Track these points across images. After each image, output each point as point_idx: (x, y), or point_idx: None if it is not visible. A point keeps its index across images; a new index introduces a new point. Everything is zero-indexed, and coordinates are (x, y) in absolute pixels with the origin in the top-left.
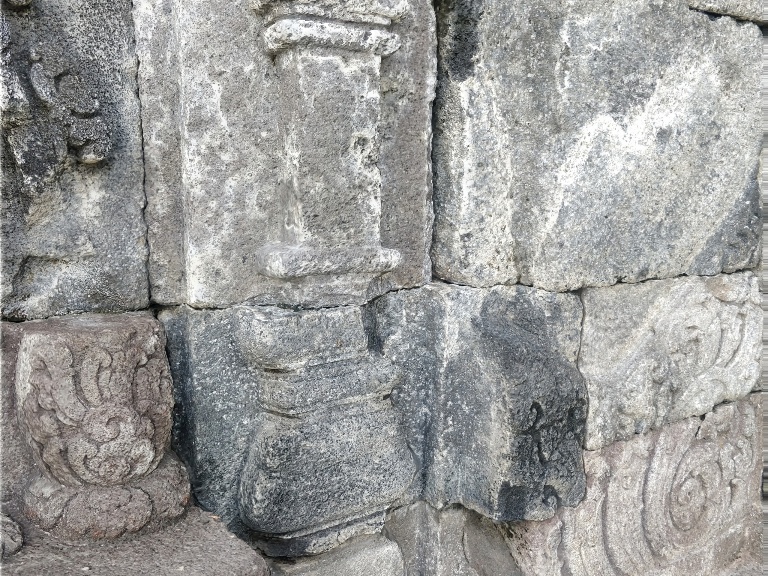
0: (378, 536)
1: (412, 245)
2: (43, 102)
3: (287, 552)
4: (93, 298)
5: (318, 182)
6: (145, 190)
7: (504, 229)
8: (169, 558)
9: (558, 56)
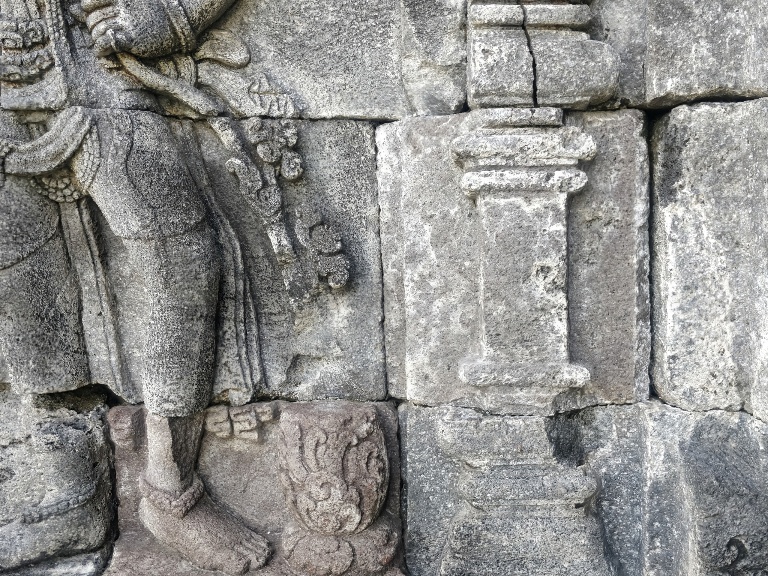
0: None
1: (621, 363)
2: None
3: None
4: (345, 389)
5: (501, 306)
6: (384, 307)
7: (723, 353)
8: None
9: (766, 177)
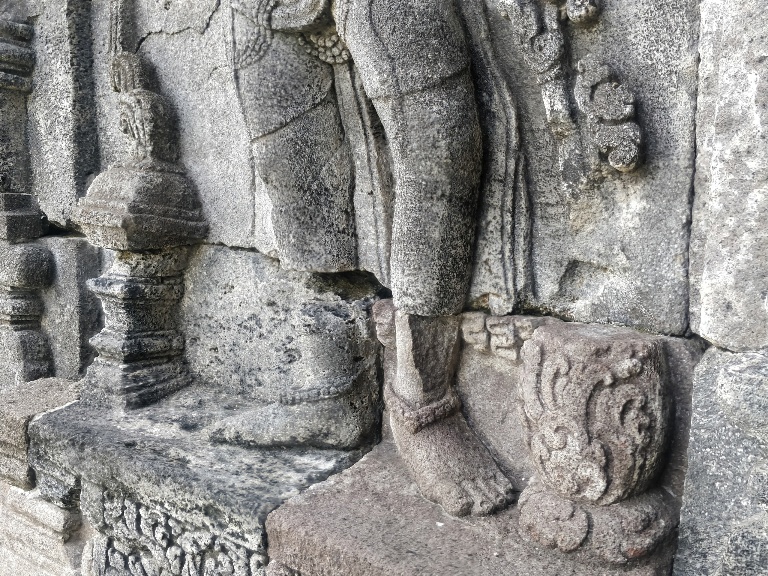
0: None
1: None
2: None
3: None
4: (634, 313)
5: None
6: (694, 203)
7: None
8: None
9: None
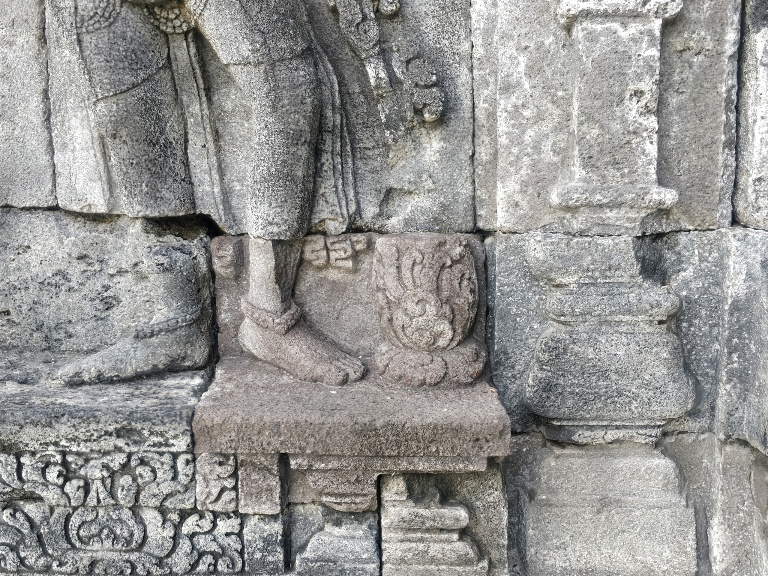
0: (650, 448)
1: (706, 190)
2: (400, 79)
3: (558, 437)
4: (435, 222)
5: (594, 129)
6: (474, 142)
7: None
8: (443, 404)
9: None
